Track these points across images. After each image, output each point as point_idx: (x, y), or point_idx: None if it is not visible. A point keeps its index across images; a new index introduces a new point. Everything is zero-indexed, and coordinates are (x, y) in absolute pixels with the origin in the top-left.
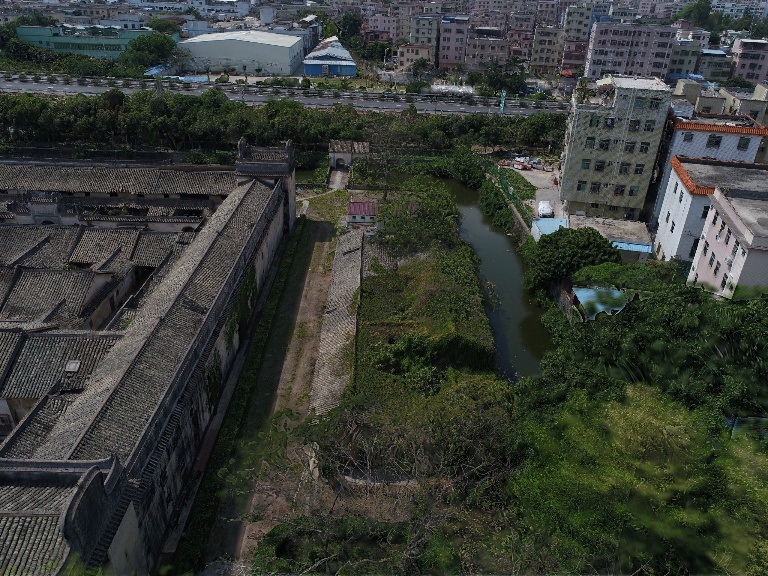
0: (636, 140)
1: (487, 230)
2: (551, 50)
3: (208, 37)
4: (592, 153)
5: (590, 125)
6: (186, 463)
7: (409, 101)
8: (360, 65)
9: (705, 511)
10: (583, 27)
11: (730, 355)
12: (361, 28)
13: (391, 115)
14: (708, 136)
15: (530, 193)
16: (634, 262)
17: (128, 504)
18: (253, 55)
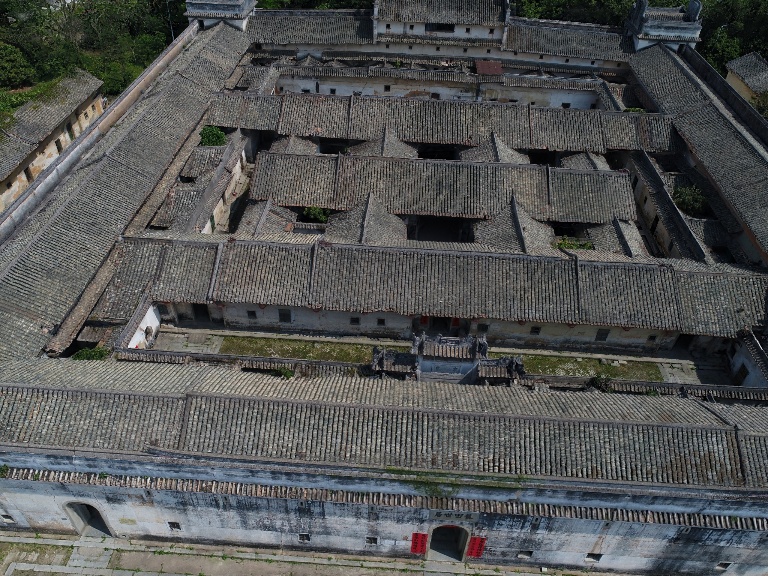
0: None
1: None
2: None
3: None
4: None
5: None
6: None
7: None
8: None
9: None
10: None
11: None
12: None
13: None
14: None
15: None
16: None
17: None
18: None
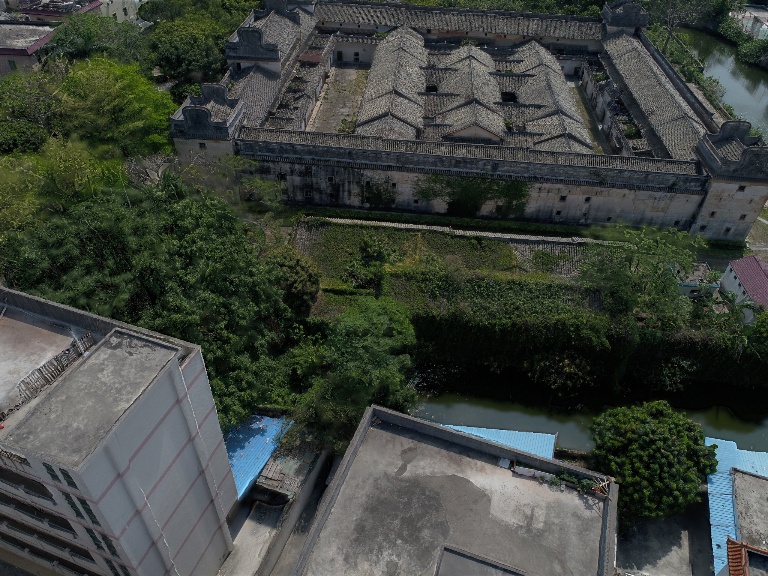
0: None
1: None
2: None
3: None
4: None
5: None
6: (313, 196)
7: None
8: None
9: None
10: None
11: None
12: None
13: None
14: None
15: None
16: None
17: (218, 139)
18: None
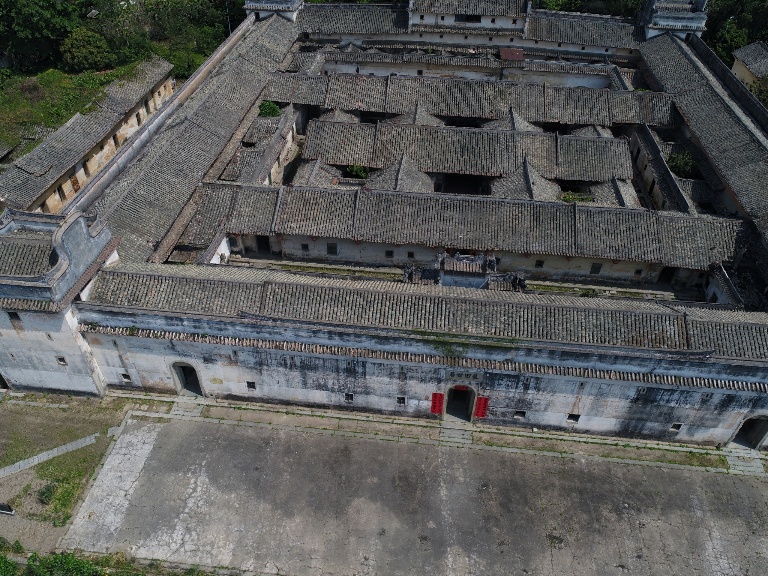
0: None
1: None
2: None
3: None
4: None
5: None
6: None
7: None
8: None
9: None
10: None
11: None
12: None
13: None
14: None
15: None
16: None
17: None
18: None
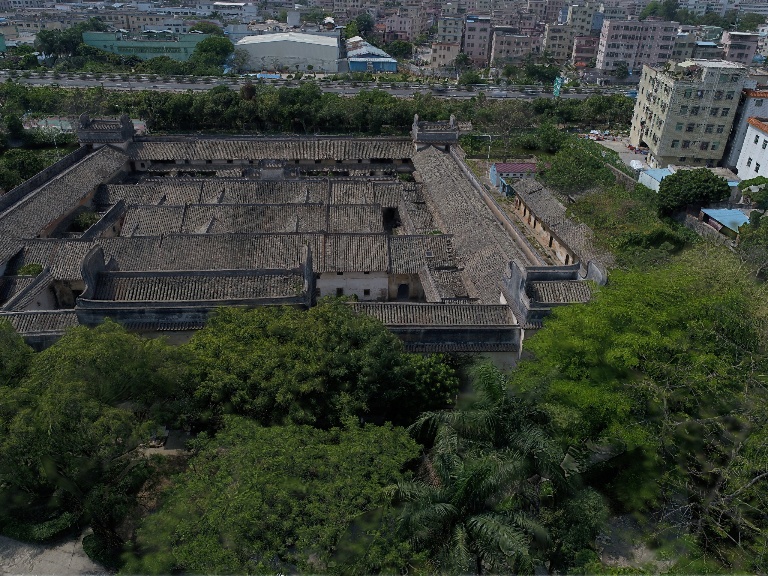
0: (719, 107)
1: None
2: (562, 45)
3: (257, 39)
4: (685, 118)
5: (684, 96)
6: None
7: (469, 90)
8: None
9: None
10: (586, 24)
11: None
12: (374, 29)
13: None
14: None
15: (616, 156)
16: None
17: None
18: (304, 54)
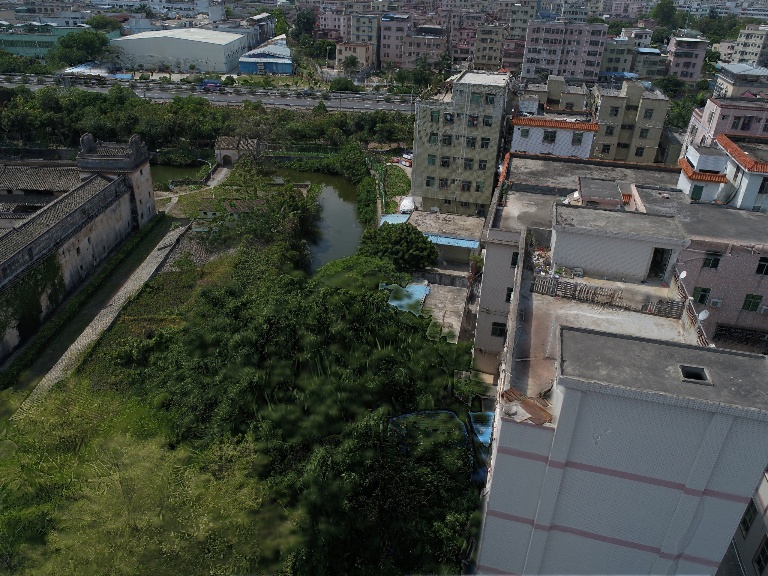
0: (476, 135)
1: (353, 227)
2: (493, 48)
3: (145, 34)
4: (436, 149)
5: (431, 120)
6: None
7: (326, 98)
8: (308, 63)
9: (382, 506)
10: None
11: (387, 348)
12: (315, 26)
13: (302, 112)
14: (543, 131)
15: (404, 190)
16: (467, 258)
17: None
18: (187, 52)
